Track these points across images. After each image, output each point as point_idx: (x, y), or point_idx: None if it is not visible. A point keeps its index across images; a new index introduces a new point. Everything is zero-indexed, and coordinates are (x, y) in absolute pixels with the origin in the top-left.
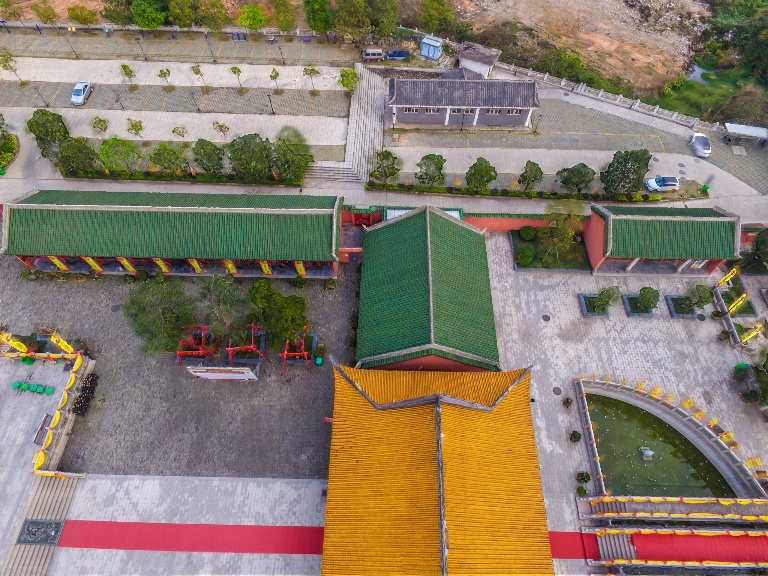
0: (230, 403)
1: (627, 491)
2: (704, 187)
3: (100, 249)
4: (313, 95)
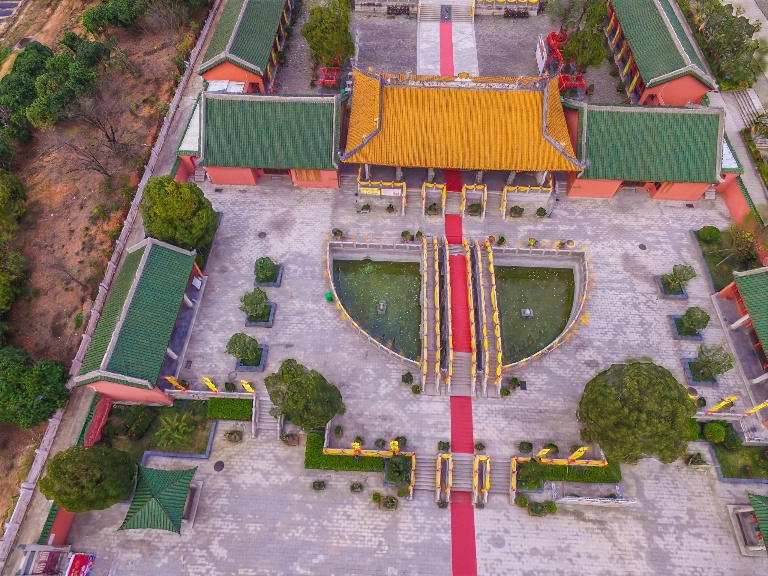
0: (522, 67)
1: None
2: None
3: None
4: None
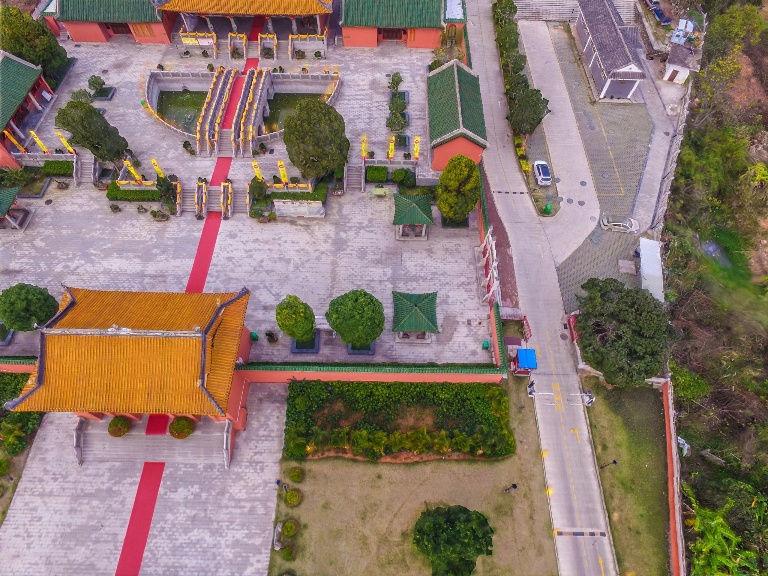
0: None
1: (277, 109)
2: (547, 204)
3: None
4: None
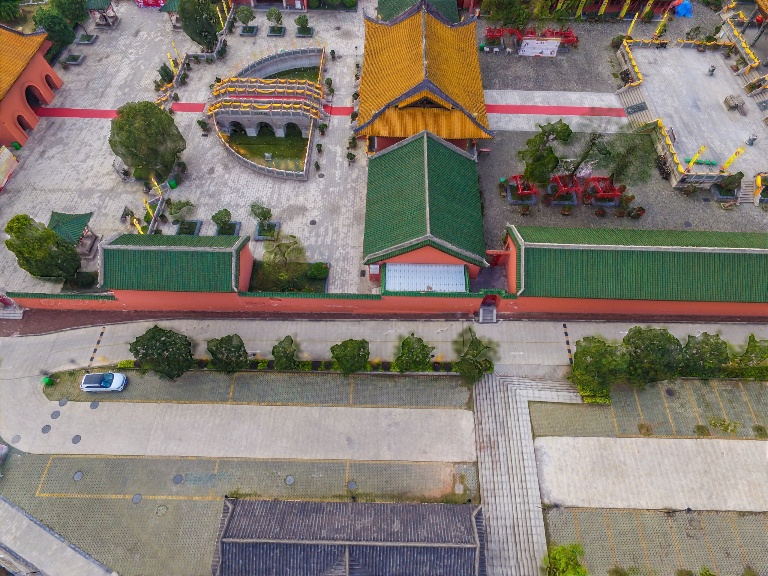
0: None
1: (290, 143)
2: (51, 379)
3: (734, 235)
4: (620, 571)
